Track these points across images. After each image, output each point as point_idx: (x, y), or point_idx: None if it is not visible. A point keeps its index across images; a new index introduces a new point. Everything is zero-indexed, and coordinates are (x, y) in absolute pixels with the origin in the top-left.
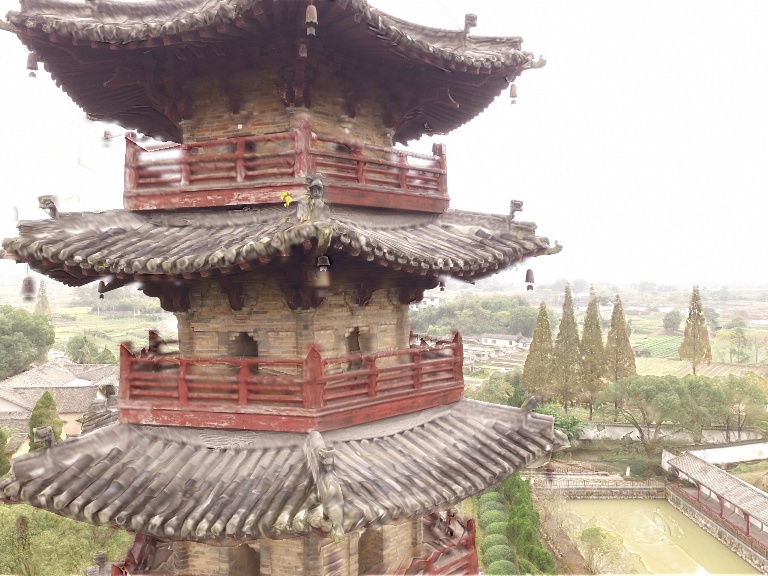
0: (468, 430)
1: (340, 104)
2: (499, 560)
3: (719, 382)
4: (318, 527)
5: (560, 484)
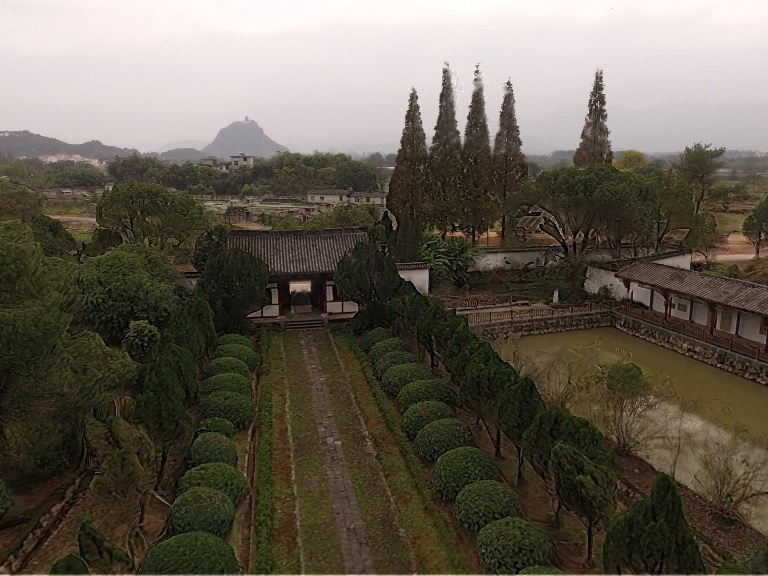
0: None
1: None
2: (453, 448)
3: None
4: None
5: (479, 319)
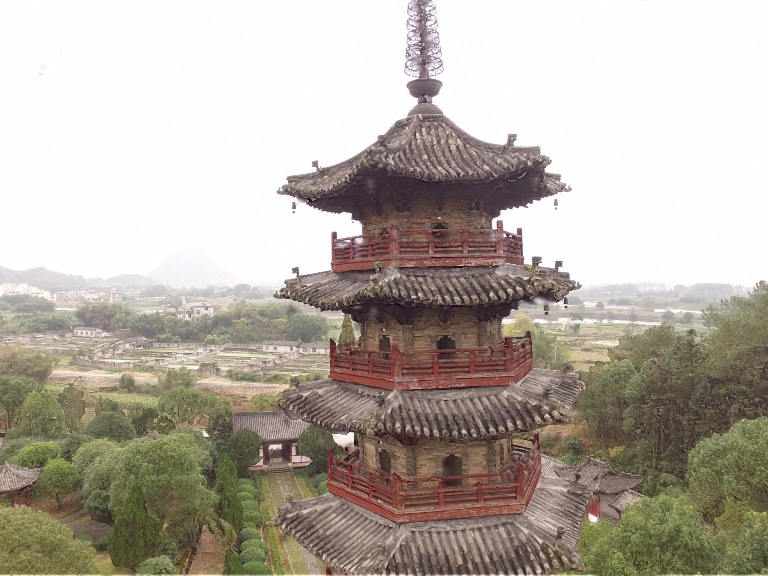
0: (543, 384)
1: (483, 206)
2: None
3: None
4: (559, 419)
5: None
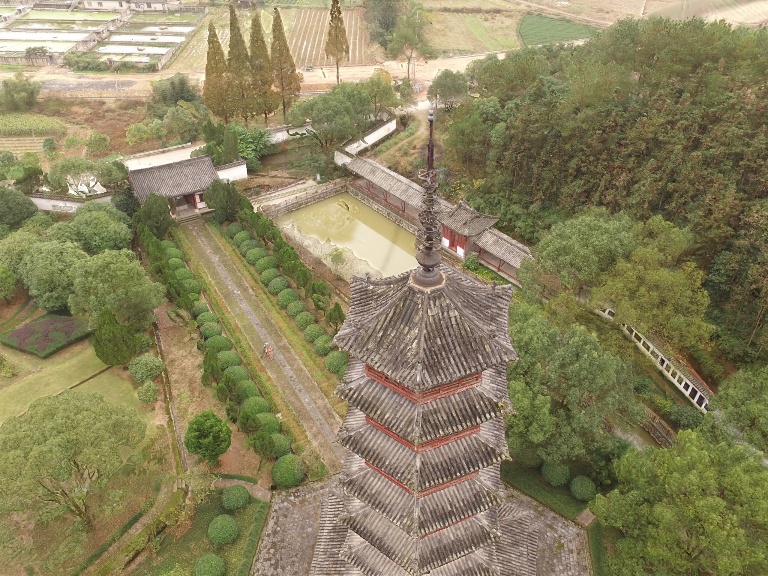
0: None
1: None
2: (283, 290)
3: (365, 87)
4: None
5: (281, 205)
